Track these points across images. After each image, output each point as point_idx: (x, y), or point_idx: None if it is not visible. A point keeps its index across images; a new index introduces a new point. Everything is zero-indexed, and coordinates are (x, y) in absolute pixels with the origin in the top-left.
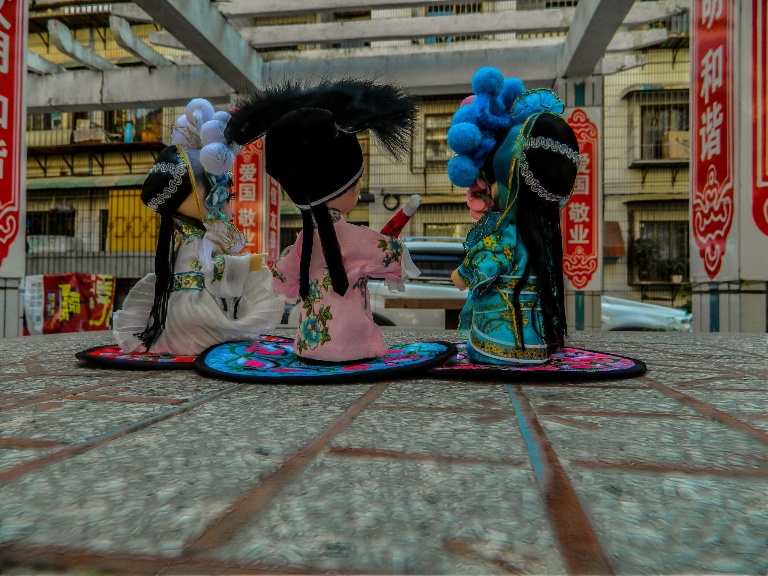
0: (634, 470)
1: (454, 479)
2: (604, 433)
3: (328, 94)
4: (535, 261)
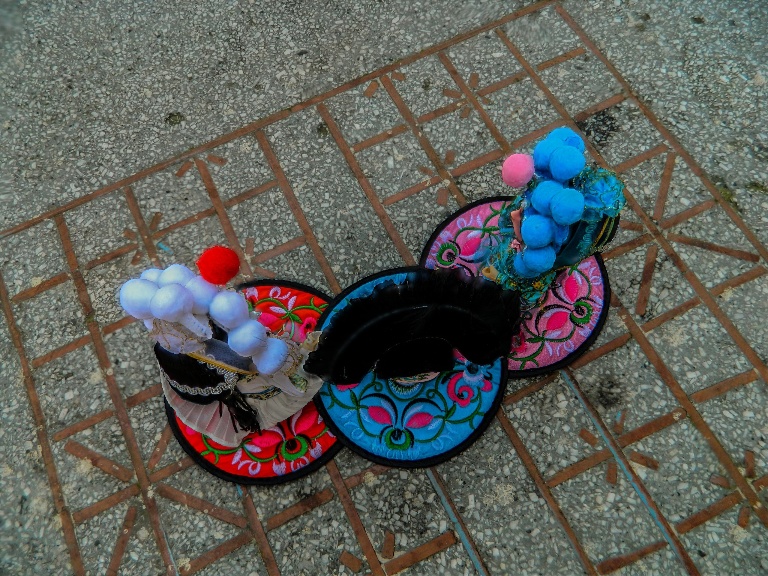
0: (694, 522)
1: (654, 570)
2: (663, 471)
3: (429, 317)
4: None
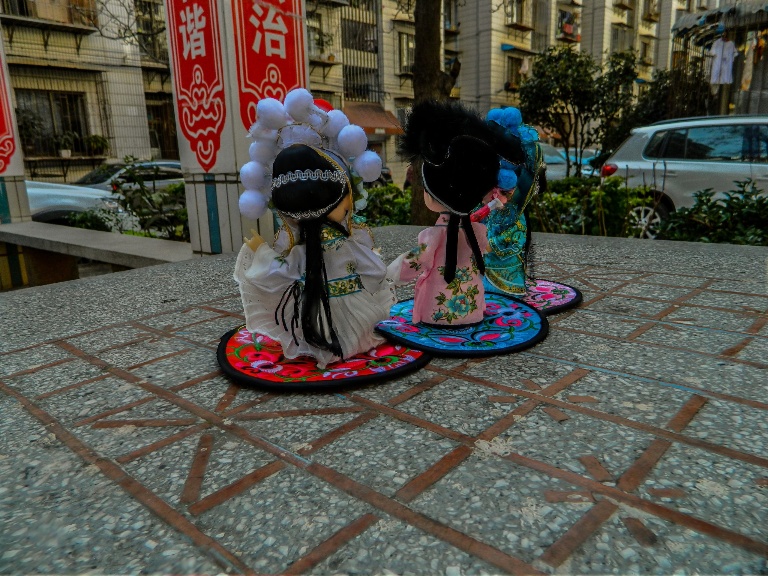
0: (755, 328)
1: None
2: None
3: (469, 123)
4: (528, 233)
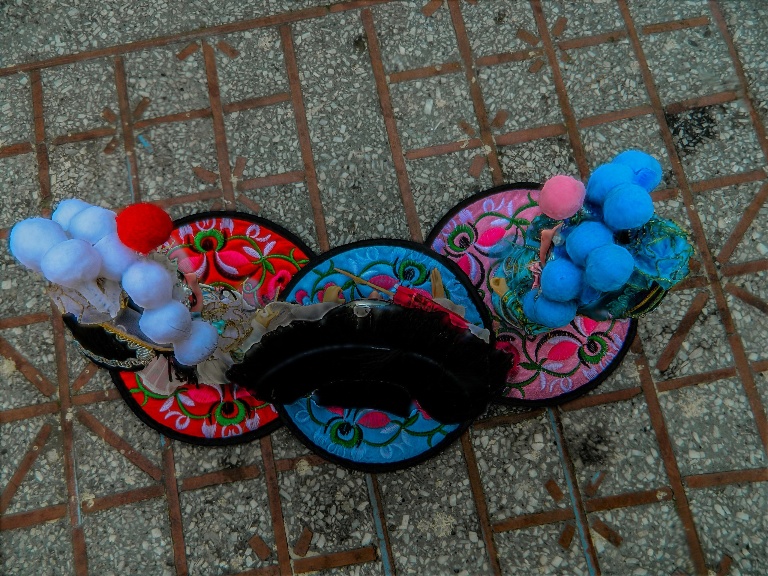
0: None
1: None
2: (624, 550)
3: None
4: None
